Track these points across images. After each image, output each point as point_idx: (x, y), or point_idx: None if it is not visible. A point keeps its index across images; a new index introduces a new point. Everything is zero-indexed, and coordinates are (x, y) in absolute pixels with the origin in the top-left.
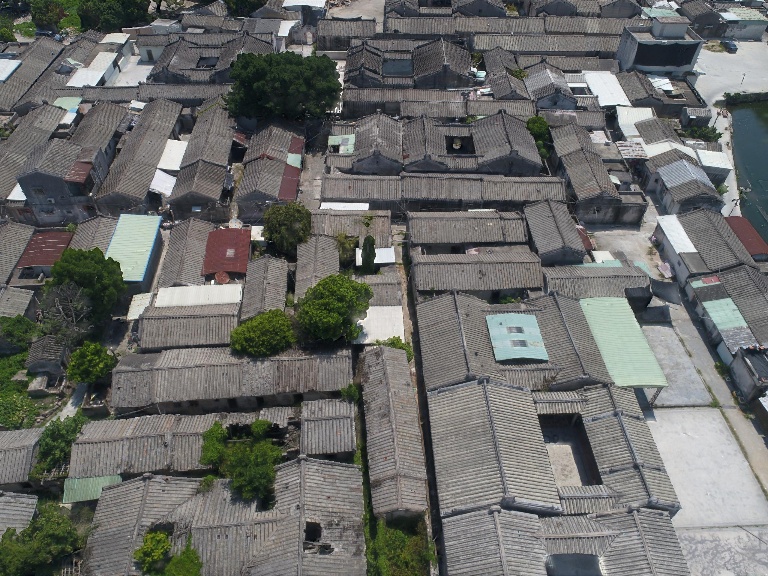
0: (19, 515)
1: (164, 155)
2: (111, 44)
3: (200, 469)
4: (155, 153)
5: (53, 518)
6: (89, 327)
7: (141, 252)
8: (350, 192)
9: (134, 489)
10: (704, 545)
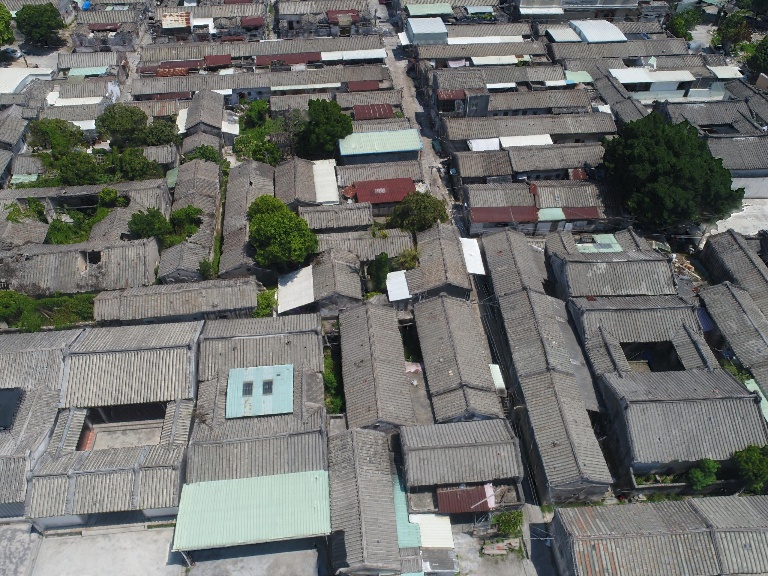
0: (161, 157)
1: (521, 137)
2: (711, 72)
3: (171, 213)
4: (518, 131)
5: (142, 159)
6: (292, 143)
7: (374, 148)
8: (494, 254)
9: (156, 185)
10: (12, 572)
